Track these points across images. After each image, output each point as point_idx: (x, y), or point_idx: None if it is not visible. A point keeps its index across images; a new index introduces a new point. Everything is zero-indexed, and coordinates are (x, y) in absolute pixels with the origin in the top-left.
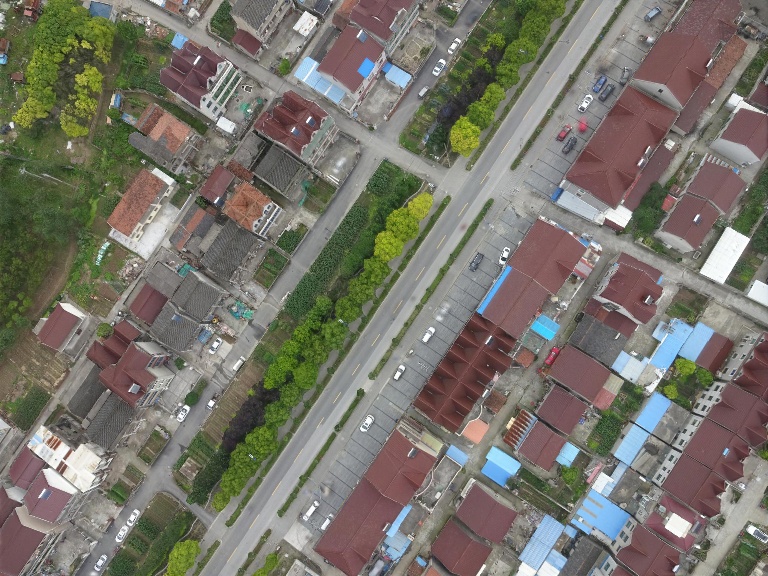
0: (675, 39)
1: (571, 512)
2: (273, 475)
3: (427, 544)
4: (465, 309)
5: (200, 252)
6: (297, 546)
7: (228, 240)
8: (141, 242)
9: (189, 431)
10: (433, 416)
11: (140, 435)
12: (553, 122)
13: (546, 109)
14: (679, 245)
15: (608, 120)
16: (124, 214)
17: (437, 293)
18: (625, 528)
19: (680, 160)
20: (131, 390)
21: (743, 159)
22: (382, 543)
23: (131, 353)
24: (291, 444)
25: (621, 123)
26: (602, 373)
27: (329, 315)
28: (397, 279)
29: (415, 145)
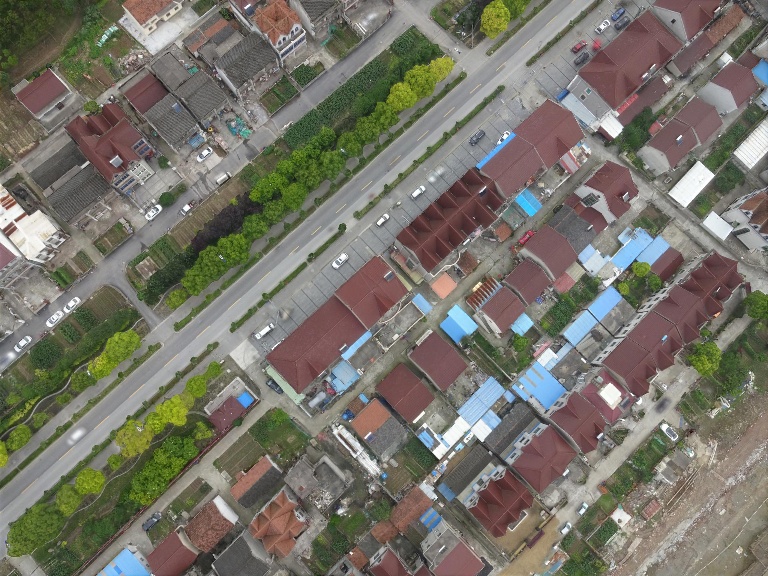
0: None
1: (513, 380)
2: (234, 290)
3: (372, 386)
4: (457, 177)
5: (213, 58)
6: (241, 364)
7: (249, 48)
8: (151, 37)
9: (155, 232)
10: (415, 248)
11: (101, 224)
12: (571, 35)
13: (568, 22)
14: (657, 164)
15: (625, 33)
16: (143, 1)
17: (434, 157)
18: (560, 399)
19: (670, 97)
20: (113, 161)
21: (723, 107)
22: None
23: (122, 126)
24: (260, 264)
25: (636, 37)
26: (571, 255)
27: (329, 148)
28: (400, 135)
29: (444, 21)
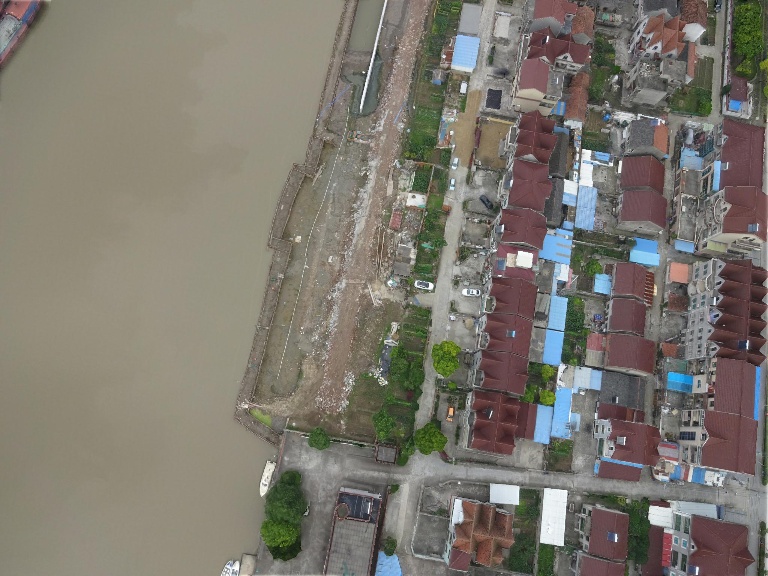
0: None
1: None
2: None
3: None
4: None
5: None
6: None
7: None
8: None
9: None
10: None
11: None
12: None
13: None
14: None
15: None
16: None
17: (762, 377)
18: None
19: None
20: None
21: None
22: (710, 155)
23: None
24: None
25: None
26: (618, 361)
27: None
28: None
29: None
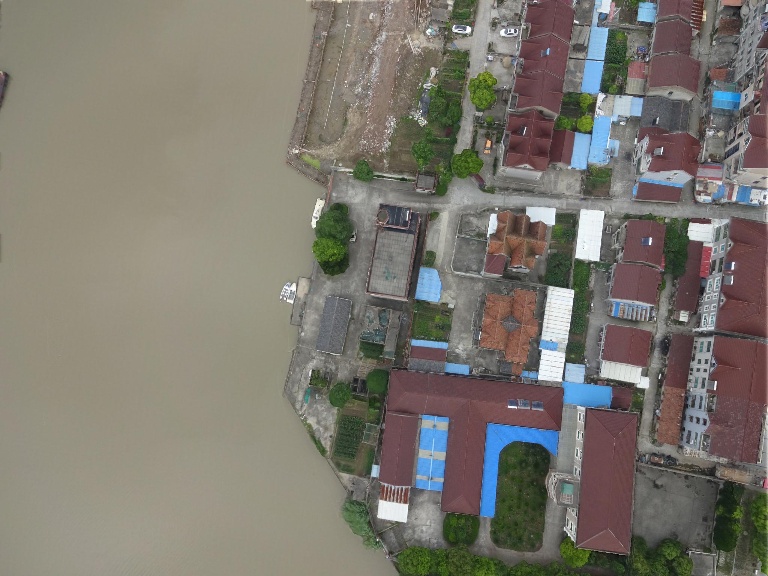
0: (762, 396)
1: None
2: None
3: None
4: None
5: None
6: None
7: None
8: None
9: None
10: None
11: None
12: None
13: None
14: None
15: None
16: None
17: None
18: None
19: (661, 311)
20: None
21: None
22: None
23: None
24: None
25: None
26: (659, 82)
27: None
28: None
29: None
